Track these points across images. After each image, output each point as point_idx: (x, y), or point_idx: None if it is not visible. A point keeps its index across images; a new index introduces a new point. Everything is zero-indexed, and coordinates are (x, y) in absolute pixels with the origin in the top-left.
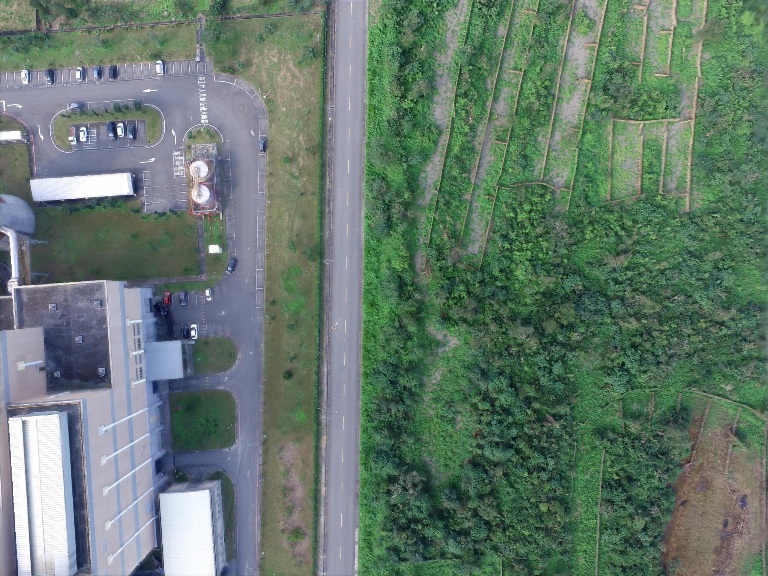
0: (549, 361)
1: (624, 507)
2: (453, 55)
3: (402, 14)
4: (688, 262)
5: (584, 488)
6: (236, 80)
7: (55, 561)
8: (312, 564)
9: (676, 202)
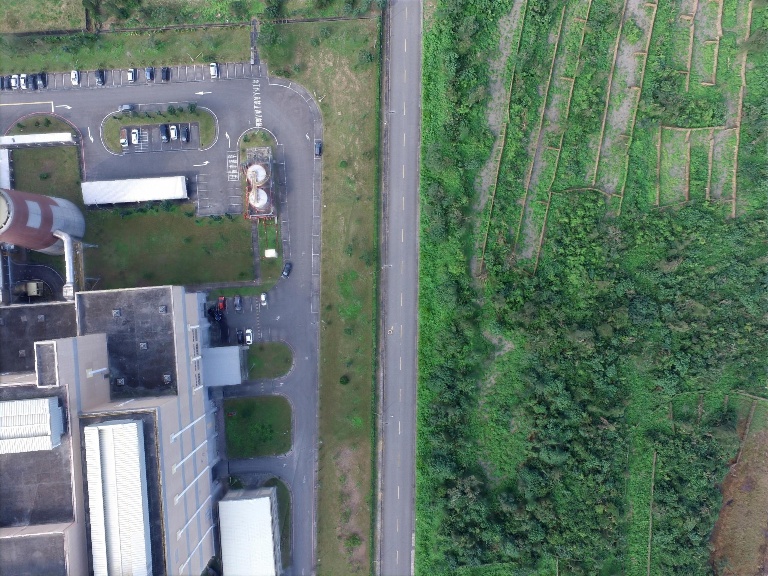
0: (603, 364)
1: (676, 508)
2: (506, 61)
3: (457, 20)
4: (735, 267)
5: (636, 490)
6: (291, 83)
7: (133, 573)
8: (369, 570)
9: (723, 208)
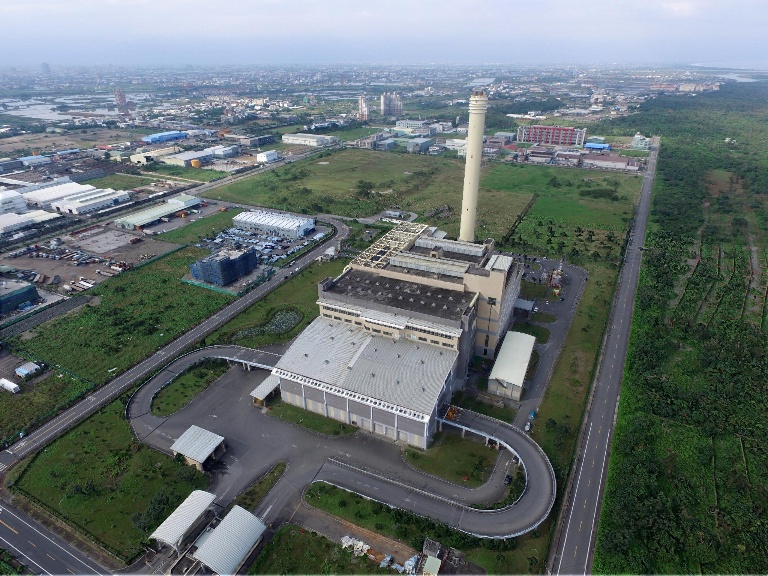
0: None
1: None
2: (683, 283)
3: None
4: None
5: None
6: None
7: None
8: None
9: None
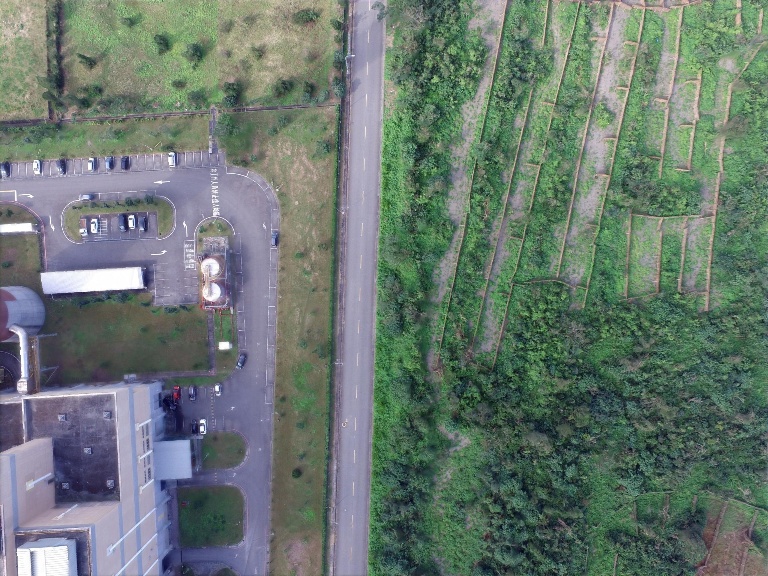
0: (562, 465)
1: None
2: (469, 148)
3: (418, 107)
4: (706, 364)
5: None
6: (249, 172)
7: None
8: None
9: (695, 301)
